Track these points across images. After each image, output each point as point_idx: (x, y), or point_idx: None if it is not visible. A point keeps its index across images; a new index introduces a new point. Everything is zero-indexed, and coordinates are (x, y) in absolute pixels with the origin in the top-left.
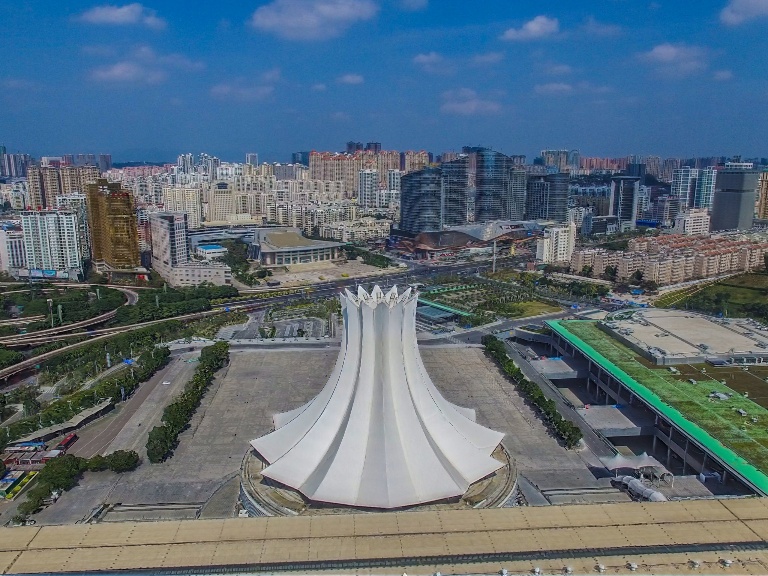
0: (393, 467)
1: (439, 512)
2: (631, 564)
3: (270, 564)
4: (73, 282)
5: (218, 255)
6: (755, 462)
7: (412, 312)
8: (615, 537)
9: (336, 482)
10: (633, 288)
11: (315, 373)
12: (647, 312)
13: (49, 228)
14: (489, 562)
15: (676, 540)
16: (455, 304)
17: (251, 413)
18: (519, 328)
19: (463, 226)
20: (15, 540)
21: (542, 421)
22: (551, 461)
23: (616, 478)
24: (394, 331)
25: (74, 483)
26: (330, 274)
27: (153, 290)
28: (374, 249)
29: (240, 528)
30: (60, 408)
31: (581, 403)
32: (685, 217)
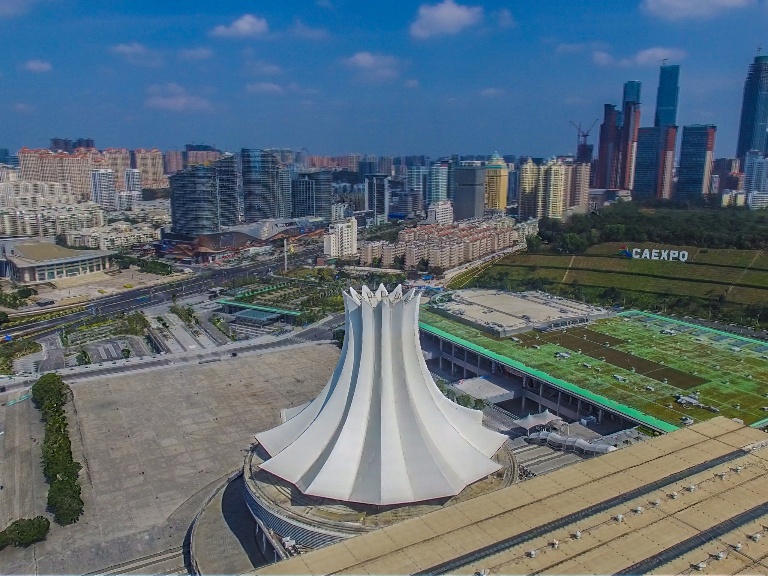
0: (434, 457)
1: (518, 485)
2: (691, 486)
3: (433, 569)
4: None
5: None
6: (625, 401)
7: None
8: (656, 471)
9: (392, 483)
10: (422, 274)
11: (183, 392)
12: (462, 293)
13: None
14: (598, 513)
15: (693, 462)
16: (277, 304)
17: (142, 446)
18: None
19: (240, 226)
20: None
21: None
22: None
23: (531, 436)
24: (407, 327)
25: None
26: (110, 286)
27: None
28: (143, 256)
29: (367, 546)
30: None
31: None
32: (435, 209)
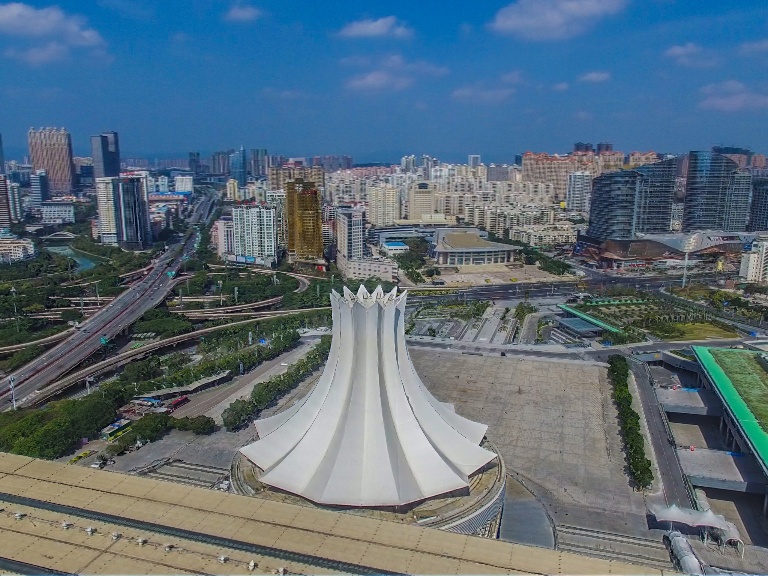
0: (346, 465)
1: (342, 515)
2: None
3: (160, 526)
4: (266, 268)
5: (399, 252)
6: None
7: (393, 314)
8: None
9: (290, 470)
10: None
11: None
12: None
13: (252, 220)
14: (342, 571)
15: None
16: (608, 318)
17: None
18: (669, 351)
19: (660, 235)
20: (11, 465)
21: (626, 455)
22: (606, 499)
23: (667, 532)
24: (371, 332)
25: (160, 437)
26: (499, 277)
27: (324, 280)
28: (559, 255)
29: (166, 491)
30: (185, 373)
31: (704, 444)
32: None
